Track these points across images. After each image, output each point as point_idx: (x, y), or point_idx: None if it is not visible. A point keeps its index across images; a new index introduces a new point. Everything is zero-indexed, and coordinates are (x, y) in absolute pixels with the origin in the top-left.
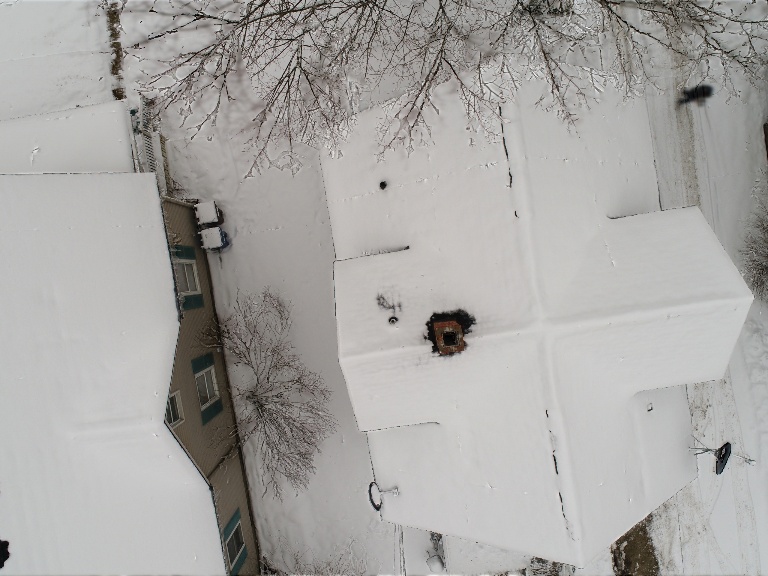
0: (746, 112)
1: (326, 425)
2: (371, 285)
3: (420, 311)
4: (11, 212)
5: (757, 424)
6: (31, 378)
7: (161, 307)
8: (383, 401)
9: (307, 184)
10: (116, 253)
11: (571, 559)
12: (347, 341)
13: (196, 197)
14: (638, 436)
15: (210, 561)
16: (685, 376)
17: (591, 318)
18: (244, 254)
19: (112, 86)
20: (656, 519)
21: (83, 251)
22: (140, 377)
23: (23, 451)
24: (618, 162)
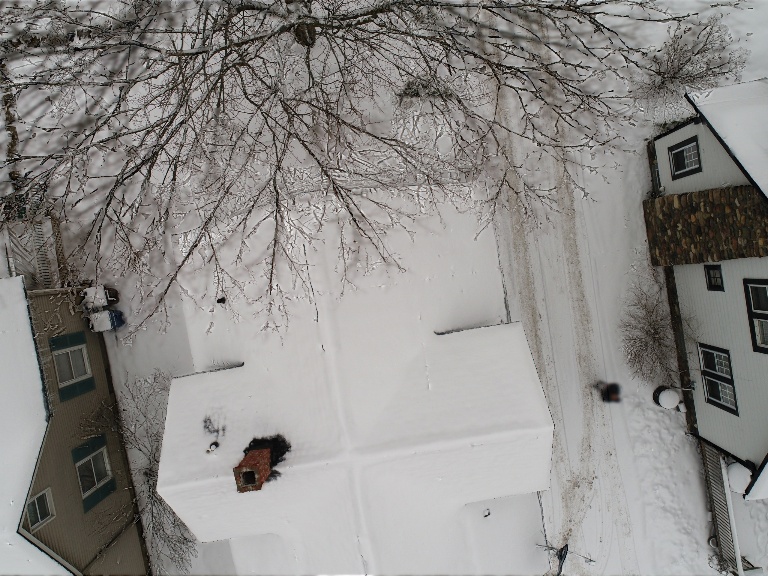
0: (624, 190)
1: None
2: (201, 406)
3: (241, 436)
4: None
5: (641, 496)
6: None
7: (27, 409)
8: (213, 519)
9: None
10: None
11: None
12: (166, 470)
13: (91, 278)
14: (471, 544)
15: None
16: (508, 490)
17: (397, 448)
18: (140, 332)
19: (8, 169)
20: None
21: None
22: None
23: None
24: (450, 275)
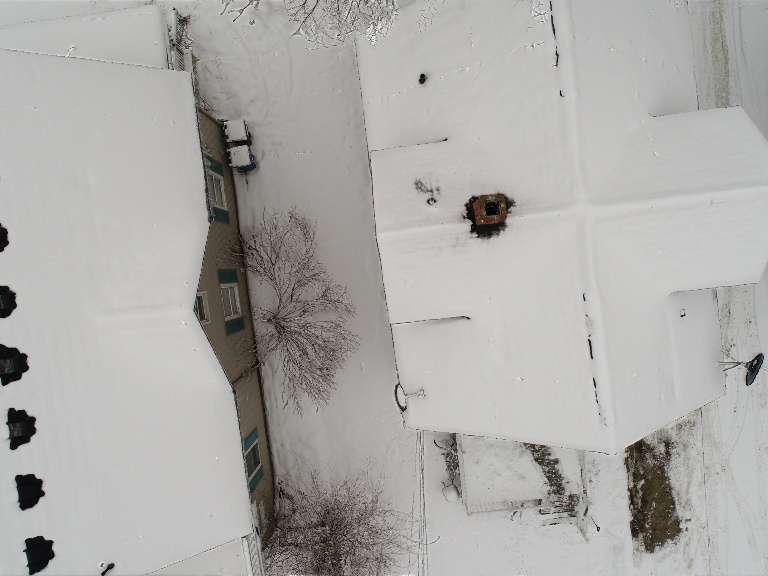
0: None
1: (348, 344)
2: (409, 171)
3: (459, 194)
4: (50, 92)
5: None
6: (63, 259)
7: (192, 205)
8: (417, 287)
9: (337, 108)
10: (150, 146)
11: (603, 445)
12: (385, 218)
13: (225, 118)
14: (671, 338)
15: (231, 463)
16: (722, 275)
17: (633, 201)
18: (271, 177)
19: None
20: (675, 458)
21: (118, 140)
22: (170, 269)
23: (53, 330)
24: (661, 63)
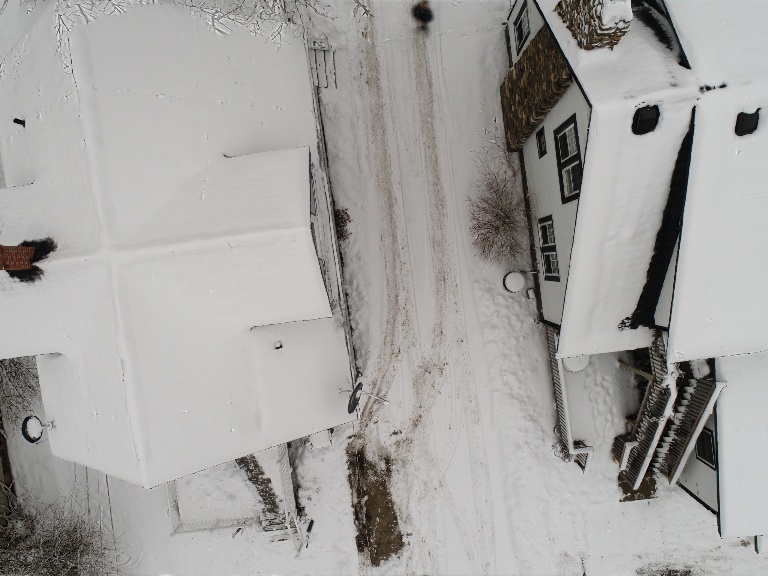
0: (481, 74)
1: None
2: None
3: (13, 239)
4: None
5: (490, 382)
6: None
7: None
8: None
9: None
10: None
11: (138, 480)
12: None
13: None
14: (256, 371)
15: None
16: (286, 311)
17: (155, 245)
18: None
19: None
20: (394, 474)
21: None
22: None
23: None
24: (249, 104)
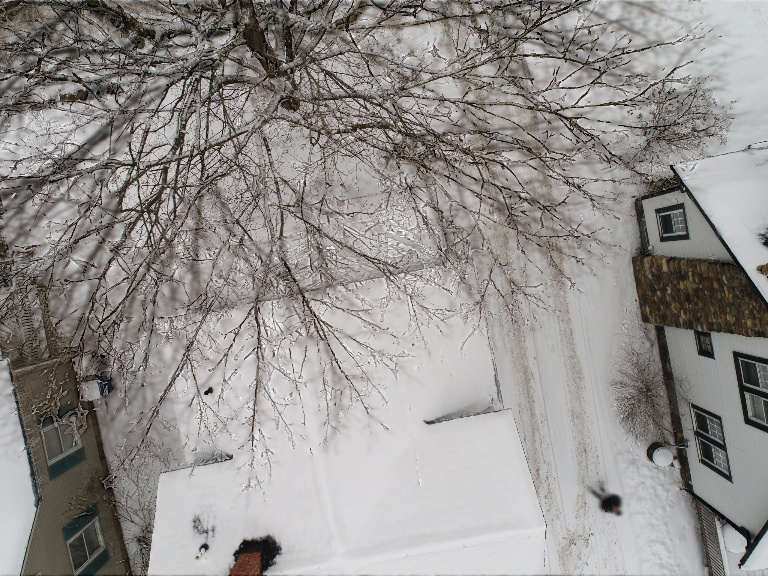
0: None
1: None
2: (189, 504)
3: (231, 537)
4: None
5: (638, 552)
6: None
7: (15, 495)
8: None
9: None
10: None
11: None
12: None
13: None
14: None
15: None
16: None
17: (388, 551)
18: (130, 398)
19: None
20: None
21: None
22: None
23: None
24: (439, 360)
